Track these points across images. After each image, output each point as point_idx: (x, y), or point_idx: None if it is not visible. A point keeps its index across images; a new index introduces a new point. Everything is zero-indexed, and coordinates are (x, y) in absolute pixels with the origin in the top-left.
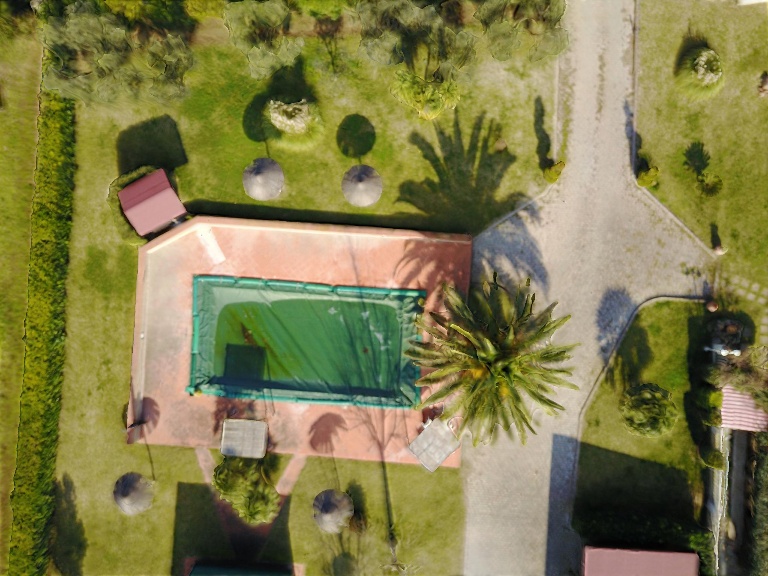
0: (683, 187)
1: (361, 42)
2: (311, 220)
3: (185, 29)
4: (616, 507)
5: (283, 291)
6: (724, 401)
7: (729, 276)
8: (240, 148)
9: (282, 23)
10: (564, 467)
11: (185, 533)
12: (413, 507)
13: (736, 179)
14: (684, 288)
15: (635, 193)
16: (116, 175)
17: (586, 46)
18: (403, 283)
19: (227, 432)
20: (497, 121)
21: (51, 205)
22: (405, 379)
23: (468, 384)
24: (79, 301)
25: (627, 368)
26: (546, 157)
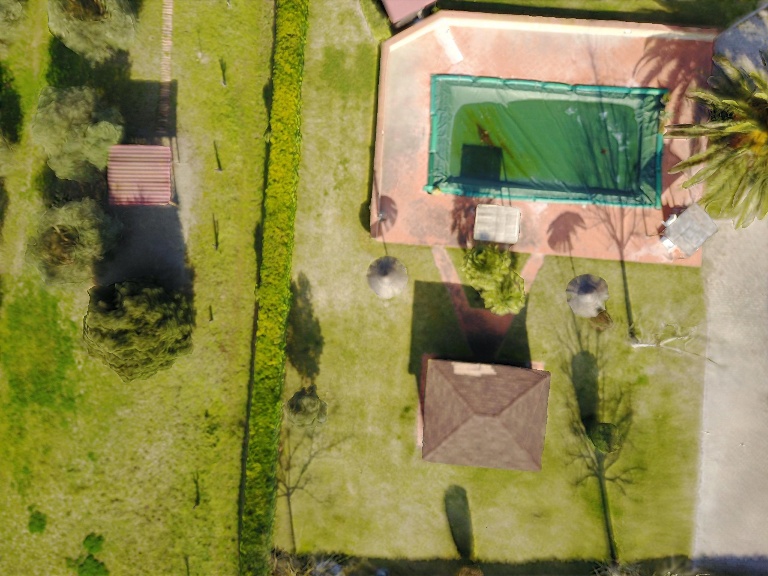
0: None
1: None
2: None
3: None
4: None
5: (522, 90)
6: None
7: None
8: None
9: None
10: None
11: (422, 331)
12: (652, 306)
13: None
14: None
15: None
16: None
17: None
18: (643, 82)
19: (480, 217)
20: None
21: None
22: (645, 178)
23: (747, 150)
24: (315, 102)
25: None
26: None
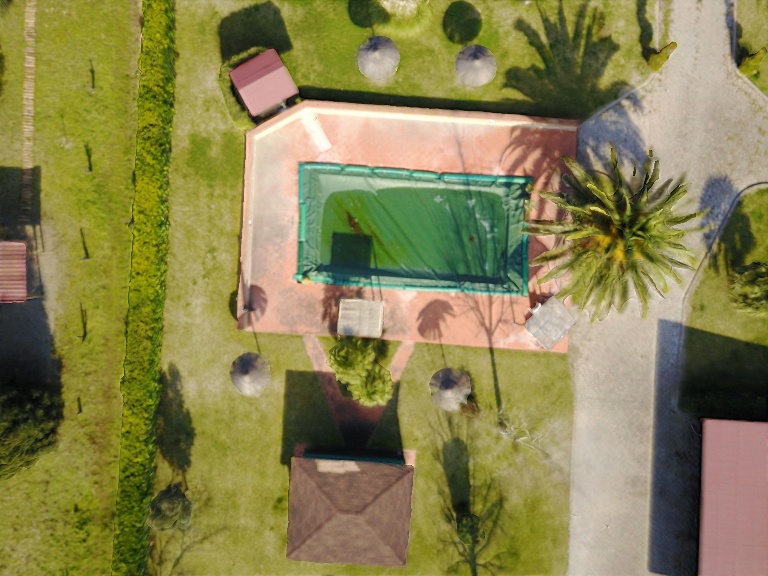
0: None
1: None
2: (419, 106)
3: None
4: (720, 388)
5: (390, 178)
6: None
7: None
8: (346, 34)
9: None
10: (668, 351)
11: (294, 421)
12: (521, 392)
13: None
14: None
15: (736, 82)
16: (220, 62)
17: None
18: (509, 170)
19: (343, 312)
20: (601, 9)
21: (158, 88)
22: (512, 265)
23: (594, 252)
24: (183, 190)
25: (729, 253)
26: (649, 46)
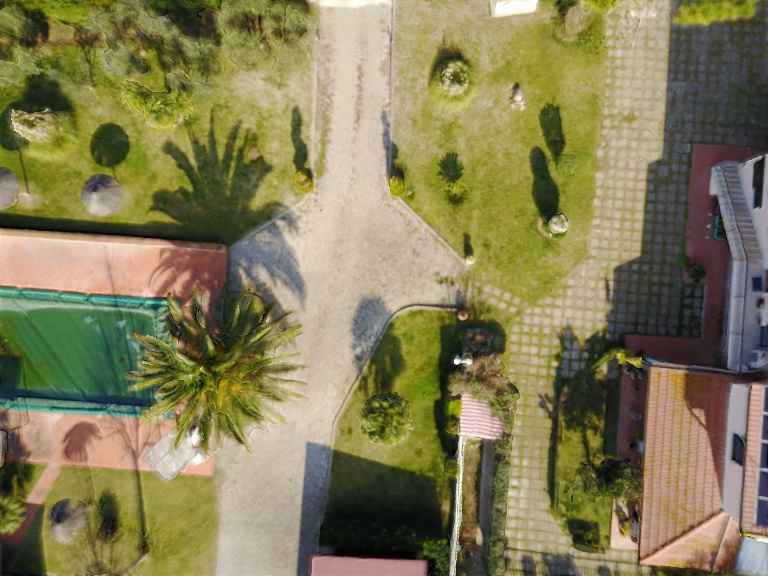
0: (437, 197)
1: (104, 51)
2: (63, 229)
3: None
4: (366, 514)
5: (37, 300)
6: (463, 409)
7: (482, 285)
8: None
9: (39, 31)
10: (318, 474)
11: None
12: (167, 515)
13: (488, 189)
14: (438, 297)
15: (391, 202)
16: None
17: (345, 56)
18: (158, 292)
19: None
20: (253, 131)
21: None
22: (159, 387)
23: None
24: None
25: (380, 376)
26: (303, 166)
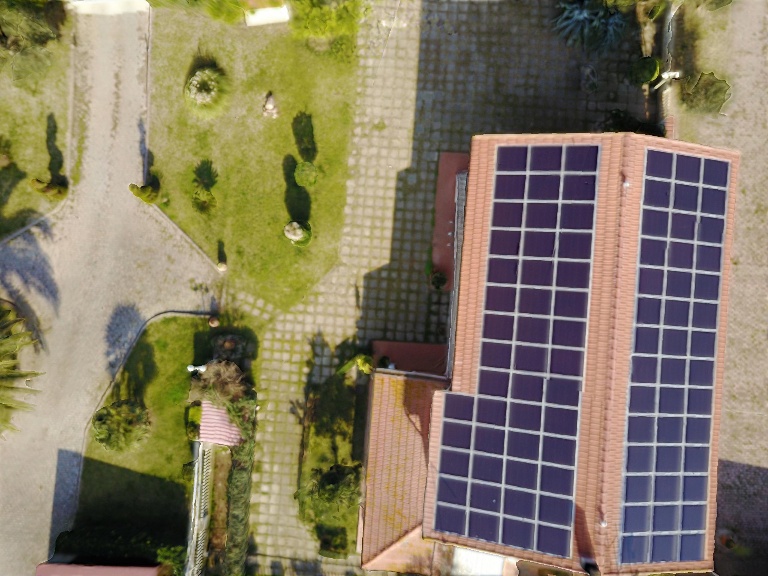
0: None
1: None
2: None
3: None
4: (115, 521)
5: None
6: (204, 415)
7: (236, 292)
8: None
9: None
10: (69, 482)
11: None
12: None
13: (242, 196)
14: (193, 303)
15: (147, 209)
16: None
17: (102, 64)
18: None
19: None
20: (7, 137)
21: None
22: None
23: None
24: None
25: (133, 383)
26: (58, 173)
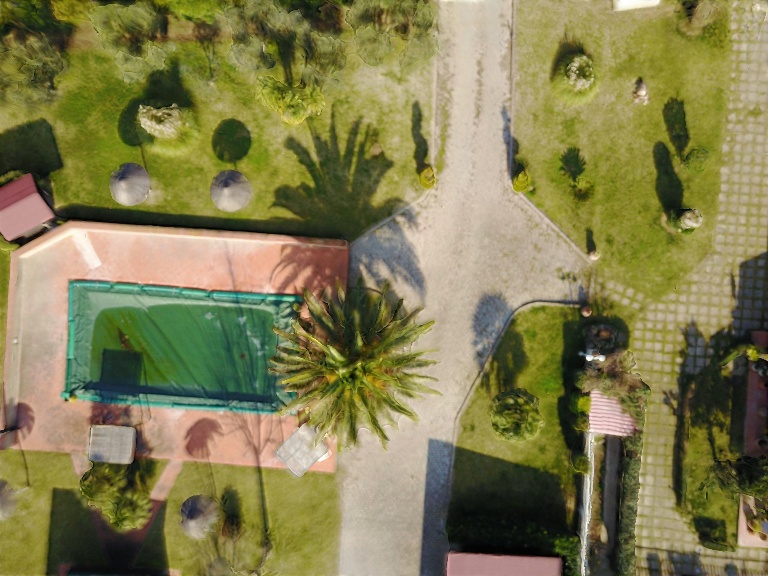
0: (559, 192)
1: (231, 47)
2: (186, 225)
3: (62, 32)
4: (490, 511)
5: (159, 296)
6: (592, 406)
7: (604, 281)
8: (115, 152)
9: (159, 27)
10: (440, 471)
11: (60, 539)
12: (289, 512)
13: (611, 184)
14: (560, 293)
15: (512, 198)
16: None
17: (464, 51)
18: (279, 288)
19: (94, 438)
20: (374, 126)
21: None
22: (281, 384)
23: (325, 390)
24: None
25: (503, 373)
26: (423, 162)
